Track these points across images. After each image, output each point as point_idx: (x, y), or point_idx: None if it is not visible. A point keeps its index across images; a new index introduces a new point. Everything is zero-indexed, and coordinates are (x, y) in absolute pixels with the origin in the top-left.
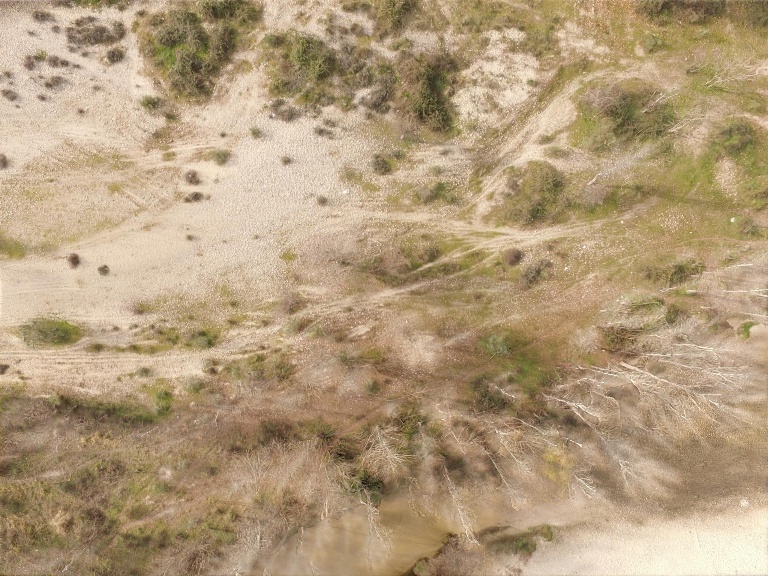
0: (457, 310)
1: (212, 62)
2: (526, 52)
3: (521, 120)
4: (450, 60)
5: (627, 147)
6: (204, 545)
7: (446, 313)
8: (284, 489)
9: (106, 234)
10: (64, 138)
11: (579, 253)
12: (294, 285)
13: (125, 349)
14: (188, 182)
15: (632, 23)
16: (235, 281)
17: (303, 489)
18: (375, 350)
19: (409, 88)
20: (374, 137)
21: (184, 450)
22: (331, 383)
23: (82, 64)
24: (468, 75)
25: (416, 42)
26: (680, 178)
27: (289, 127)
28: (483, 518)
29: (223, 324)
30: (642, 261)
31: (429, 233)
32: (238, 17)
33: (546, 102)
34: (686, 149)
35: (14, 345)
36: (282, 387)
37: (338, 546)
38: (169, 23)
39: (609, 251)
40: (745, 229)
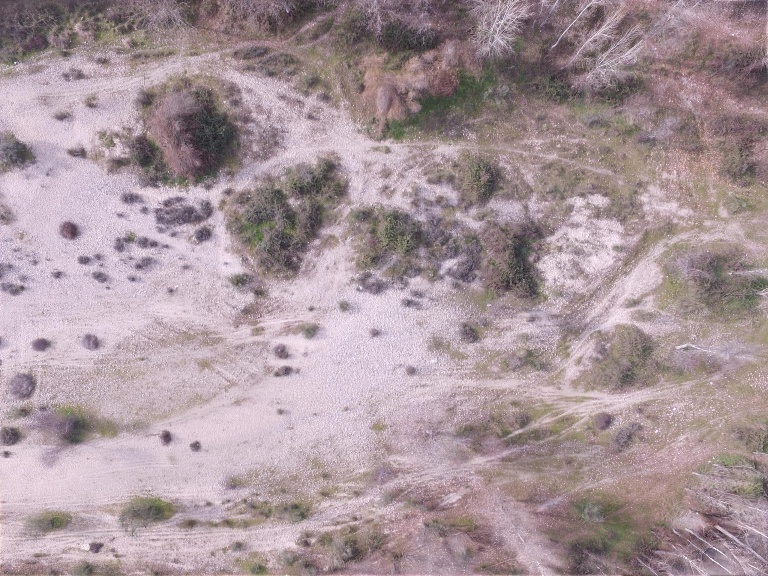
0: (548, 475)
1: (299, 239)
2: (610, 218)
3: (607, 284)
4: (535, 229)
5: (714, 308)
6: None
7: (537, 479)
8: None
9: (197, 410)
10: (154, 317)
11: (669, 415)
12: (385, 455)
13: (218, 524)
14: (277, 356)
15: (715, 184)
16: (326, 453)
17: None
18: (467, 517)
19: (495, 257)
20: (461, 305)
21: None
22: (424, 551)
23: (170, 244)
24: (553, 242)
25: (501, 211)
26: None
27: (376, 299)
28: None
29: (315, 496)
30: (733, 422)
31: (518, 400)
32: (324, 194)
33: (631, 266)
34: None
35: (108, 523)
36: (375, 557)
37: None
38: (256, 201)
39: (699, 412)
40: None
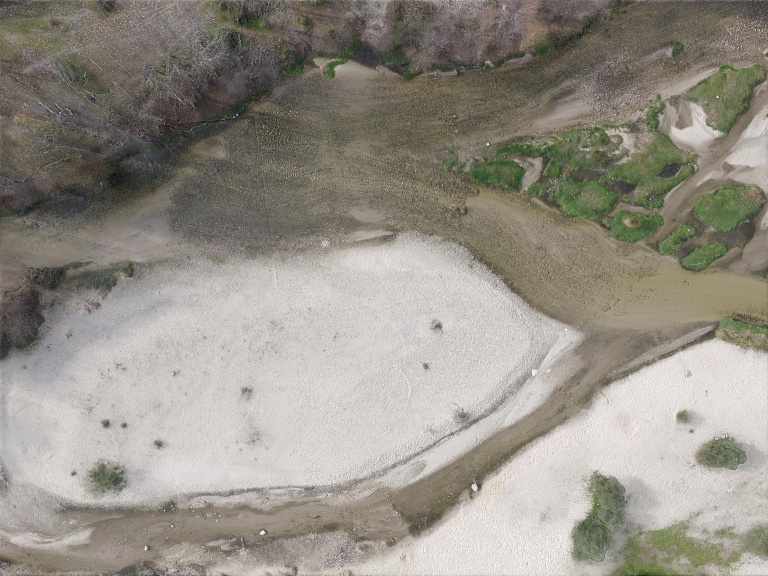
0: (35, 37)
1: None
2: None
3: None
4: None
5: None
6: None
7: (23, 40)
8: None
9: None
10: None
11: None
12: None
13: None
14: None
15: None
16: None
17: None
18: None
19: None
20: None
21: None
22: None
23: None
24: None
25: None
26: None
27: None
28: (66, 253)
29: None
30: None
31: None
32: None
33: None
34: None
35: None
36: None
37: None
38: None
39: None
40: None
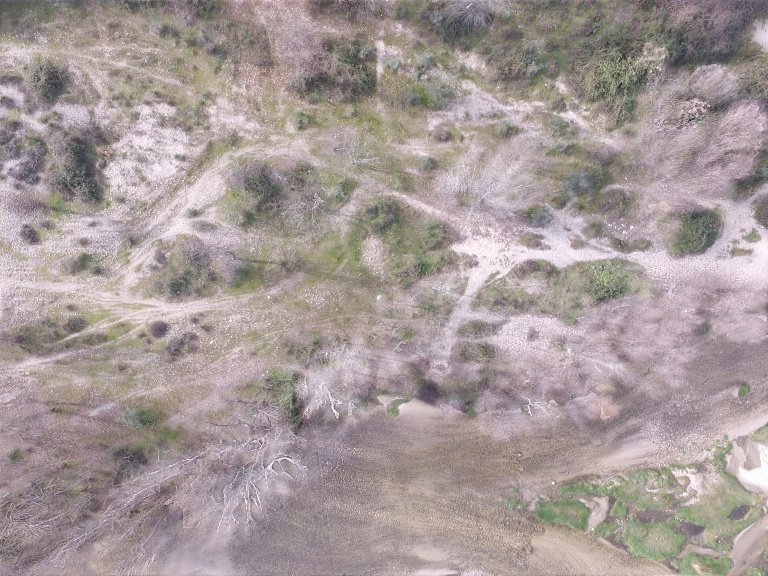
0: (103, 380)
1: None
2: (175, 127)
3: (170, 194)
4: (97, 134)
5: (274, 223)
6: None
7: (92, 383)
8: None
9: None
10: None
11: (225, 327)
12: None
13: None
14: None
15: (283, 100)
16: None
17: None
18: (20, 418)
19: (58, 160)
20: (24, 207)
21: None
22: None
23: None
24: (118, 148)
25: (65, 115)
26: (327, 255)
27: None
28: None
29: None
30: (288, 336)
31: (76, 303)
32: None
33: (195, 176)
34: (334, 226)
35: None
36: None
37: None
38: None
39: (255, 325)
40: (385, 308)
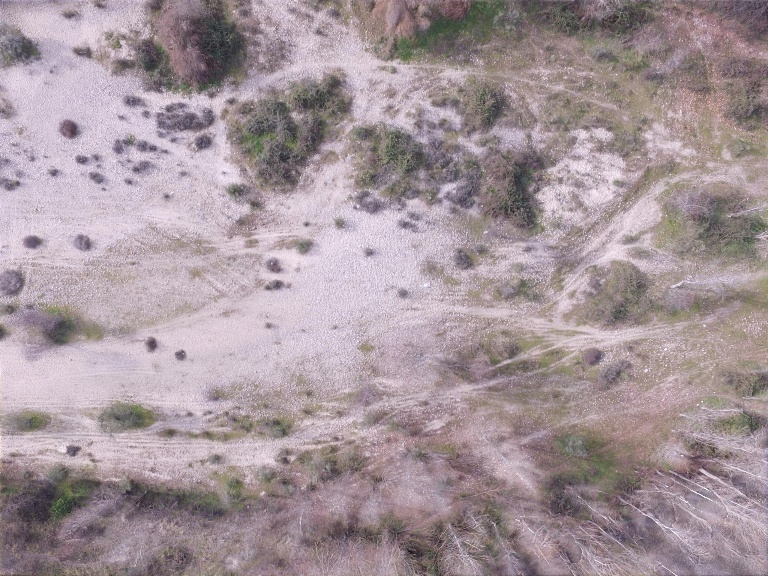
0: (534, 408)
1: (300, 152)
2: (613, 152)
3: (605, 219)
4: (537, 158)
5: (712, 251)
6: None
7: (523, 411)
8: None
9: (185, 319)
10: (148, 222)
11: (660, 355)
12: (371, 377)
13: (198, 435)
14: (269, 270)
15: (720, 127)
16: (312, 370)
17: None
18: (450, 445)
19: (494, 184)
20: (457, 231)
21: (252, 540)
22: (404, 477)
23: (170, 149)
24: (554, 173)
25: (503, 139)
26: (764, 284)
27: (373, 219)
28: None
29: (298, 413)
30: (724, 366)
31: (509, 329)
32: (327, 109)
33: (631, 202)
34: None
35: (87, 427)
36: (354, 479)
37: None
38: (258, 112)
39: (690, 354)
40: None
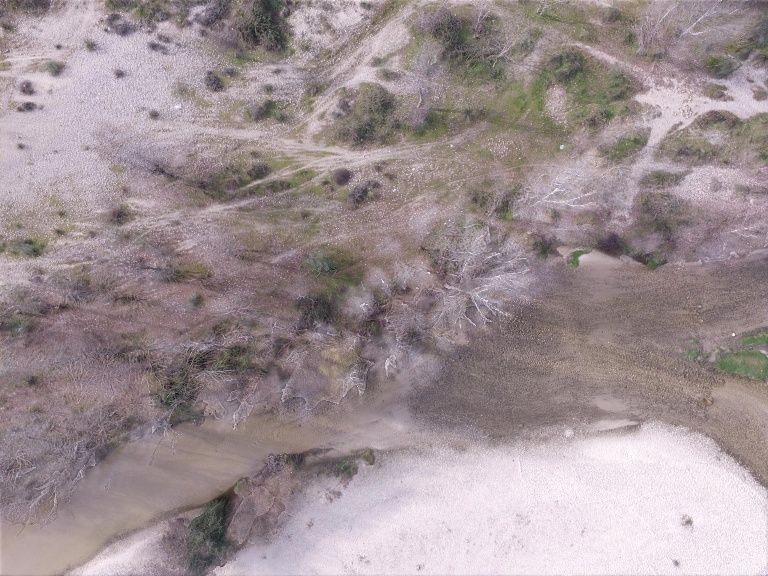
0: (285, 228)
1: None
2: None
3: (354, 42)
4: None
5: (458, 72)
6: (21, 454)
7: (274, 230)
8: (105, 401)
9: None
10: None
11: (408, 175)
12: (123, 197)
13: None
14: (22, 92)
15: None
16: (65, 191)
17: (124, 402)
18: (202, 265)
19: (244, 7)
20: (208, 54)
21: (7, 358)
22: (157, 296)
23: None
24: None
25: None
26: (510, 104)
27: (124, 41)
28: (306, 439)
29: (51, 233)
30: (471, 185)
31: (259, 150)
32: None
33: (379, 25)
34: (517, 76)
35: None
36: (107, 299)
37: (159, 462)
38: None
39: (438, 174)
40: (571, 155)
